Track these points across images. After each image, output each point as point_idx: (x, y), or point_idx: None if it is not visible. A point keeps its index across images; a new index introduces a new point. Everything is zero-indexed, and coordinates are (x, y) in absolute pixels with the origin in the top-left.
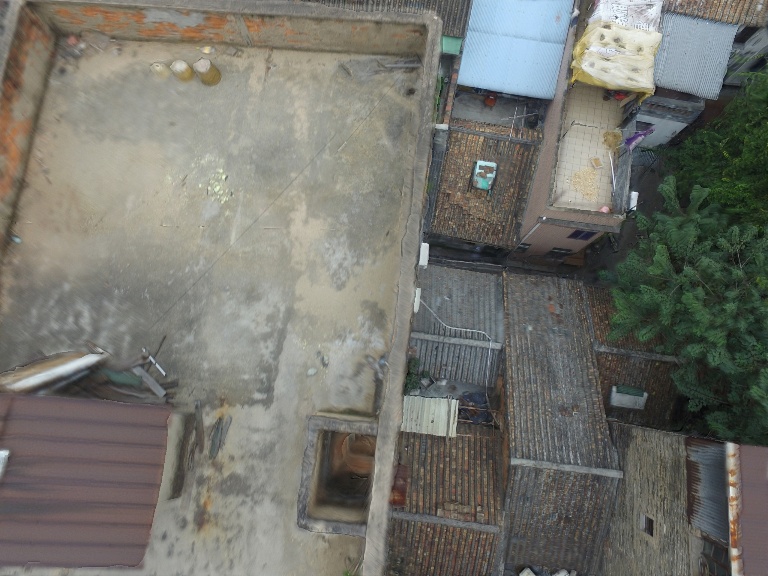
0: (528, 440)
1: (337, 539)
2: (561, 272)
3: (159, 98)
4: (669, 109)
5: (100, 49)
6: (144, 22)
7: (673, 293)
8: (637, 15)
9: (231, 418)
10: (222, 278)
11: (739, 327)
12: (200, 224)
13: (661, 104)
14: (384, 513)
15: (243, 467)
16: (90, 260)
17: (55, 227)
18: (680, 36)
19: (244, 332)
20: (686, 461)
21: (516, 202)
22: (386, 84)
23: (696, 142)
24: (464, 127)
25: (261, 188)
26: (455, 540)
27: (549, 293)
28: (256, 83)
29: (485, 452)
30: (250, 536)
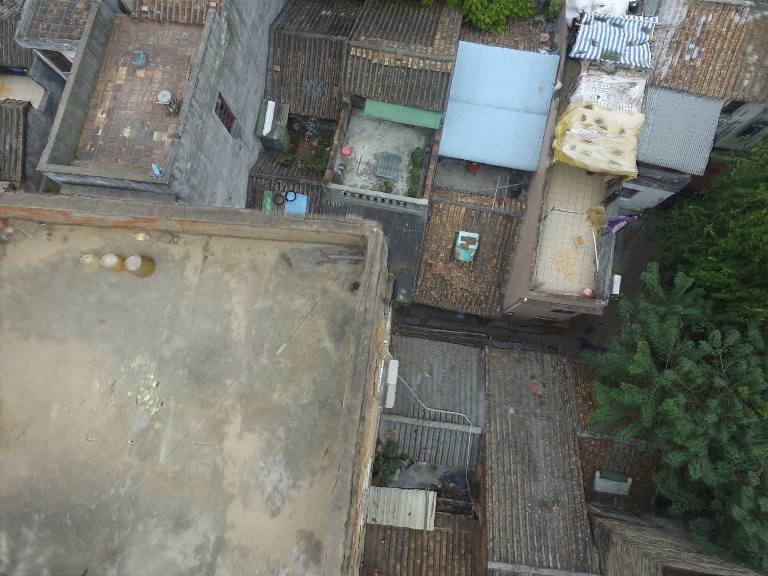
0: (506, 540)
1: None
2: (548, 333)
3: (89, 291)
4: (655, 179)
5: (29, 234)
6: (71, 216)
7: (654, 392)
8: (620, 94)
9: None
10: (149, 502)
11: (721, 438)
12: (128, 438)
13: (647, 175)
14: None
15: None
16: (10, 480)
17: None
18: (665, 110)
19: (171, 566)
20: None
21: (499, 273)
22: (329, 278)
23: (683, 212)
24: (446, 197)
25: (194, 396)
26: None
27: (532, 370)
28: (192, 275)
29: (464, 546)
30: None
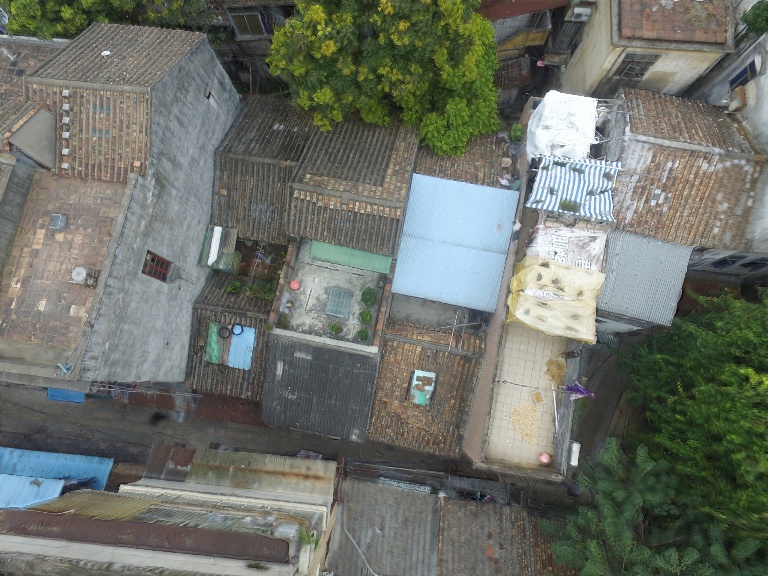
0: None
1: None
2: None
3: None
4: (622, 318)
5: None
6: None
7: None
8: (578, 249)
9: None
10: None
11: None
12: None
13: (613, 314)
14: None
15: None
16: None
17: None
18: (630, 255)
19: None
20: None
21: (457, 413)
22: None
23: (652, 352)
24: (400, 335)
25: None
26: None
27: (489, 527)
28: None
29: None
30: None
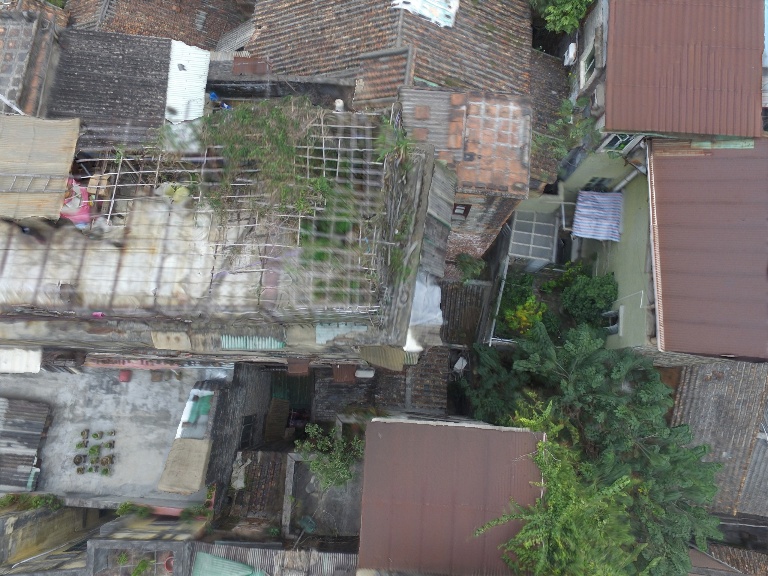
0: None
1: None
2: None
3: None
4: None
5: None
6: None
7: None
8: None
9: None
10: None
11: None
12: None
13: None
14: None
15: None
16: None
17: None
18: None
19: None
20: None
21: None
22: None
23: None
24: None
25: None
26: None
27: None
28: None
29: None
30: None
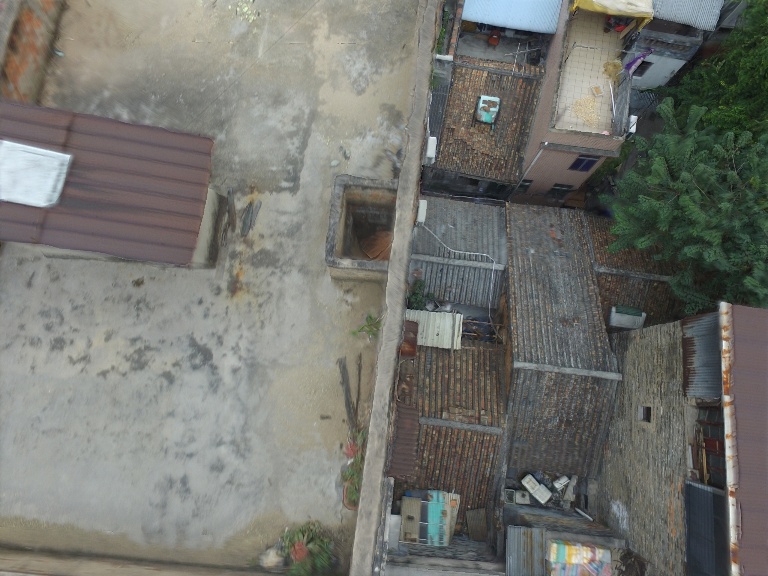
0: (530, 347)
1: (359, 303)
2: None
3: None
4: (668, 45)
5: None
6: None
7: (671, 202)
8: None
9: (261, 203)
10: (251, 85)
11: (734, 225)
12: (230, 40)
13: (660, 39)
14: (405, 250)
15: (272, 244)
16: (128, 71)
17: (95, 43)
18: None
19: (272, 131)
20: (682, 341)
21: (519, 136)
22: None
23: (694, 77)
24: (468, 62)
25: (286, 9)
26: (460, 443)
27: (551, 221)
28: None
29: (488, 364)
30: (279, 302)
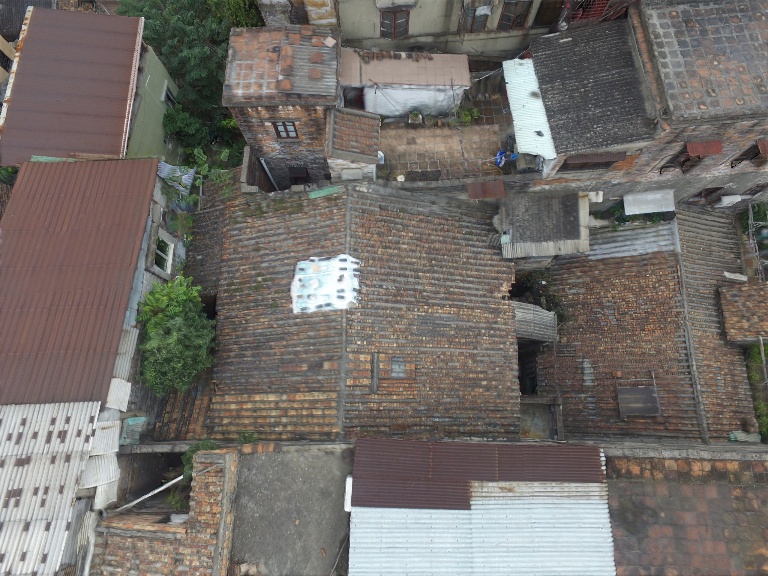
0: None
1: None
2: None
3: None
4: None
5: None
6: None
7: None
8: None
9: None
10: None
11: None
12: None
13: None
14: None
15: None
16: None
17: None
18: None
19: None
20: None
21: None
22: None
23: None
24: None
25: None
26: (4, 193)
27: None
28: None
29: None
30: None
